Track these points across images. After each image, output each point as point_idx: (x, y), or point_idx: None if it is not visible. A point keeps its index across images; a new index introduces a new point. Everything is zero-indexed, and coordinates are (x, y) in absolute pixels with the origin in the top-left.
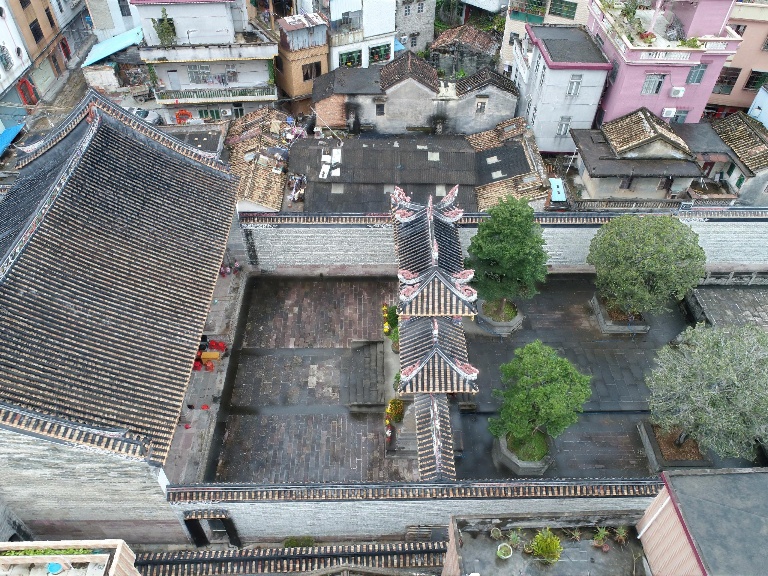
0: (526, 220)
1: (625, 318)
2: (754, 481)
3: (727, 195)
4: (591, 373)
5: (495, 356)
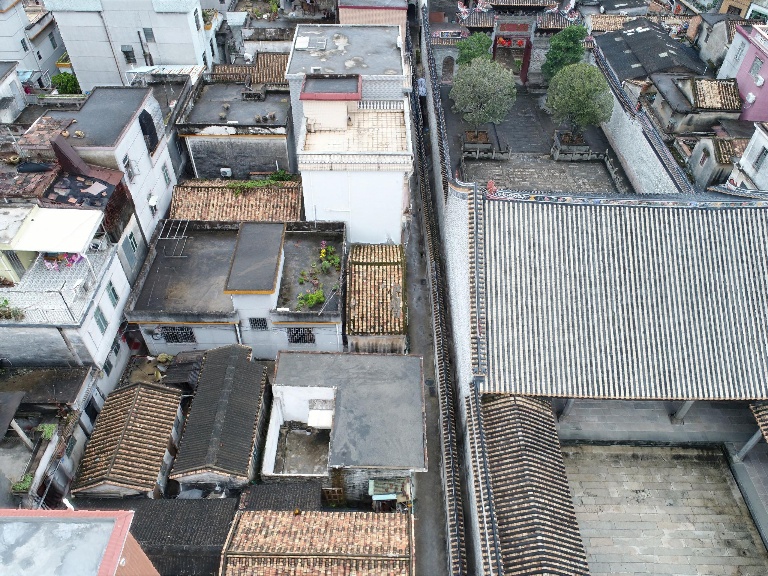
0: (569, 33)
1: (566, 140)
2: (403, 1)
3: (689, 152)
4: (519, 126)
5: (523, 102)
